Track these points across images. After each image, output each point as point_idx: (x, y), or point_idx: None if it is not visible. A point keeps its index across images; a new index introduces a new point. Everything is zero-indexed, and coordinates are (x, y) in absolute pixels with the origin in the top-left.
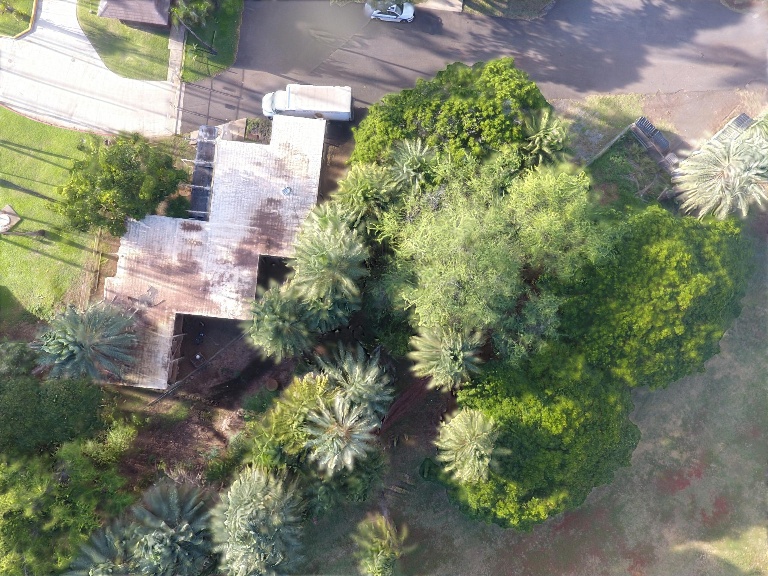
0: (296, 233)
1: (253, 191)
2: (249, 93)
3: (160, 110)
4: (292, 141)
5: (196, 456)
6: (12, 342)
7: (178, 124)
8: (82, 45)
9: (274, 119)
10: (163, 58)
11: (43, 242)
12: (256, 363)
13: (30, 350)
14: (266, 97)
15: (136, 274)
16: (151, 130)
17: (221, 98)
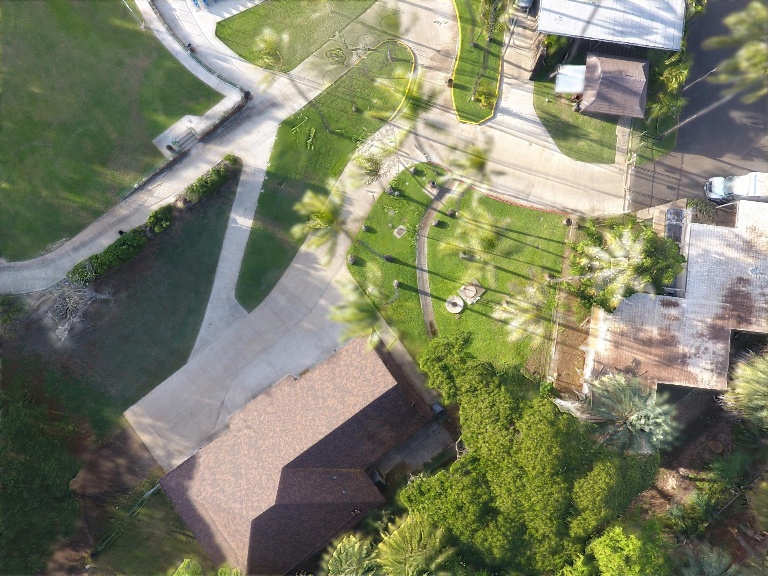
0: (763, 309)
1: (724, 270)
2: (688, 175)
3: (609, 191)
4: (758, 224)
5: (642, 513)
6: None
7: (626, 204)
8: (538, 131)
9: (741, 204)
10: (611, 143)
11: (505, 312)
12: (691, 425)
13: (591, 424)
14: (717, 181)
15: (621, 346)
16: (601, 209)
17: (663, 180)
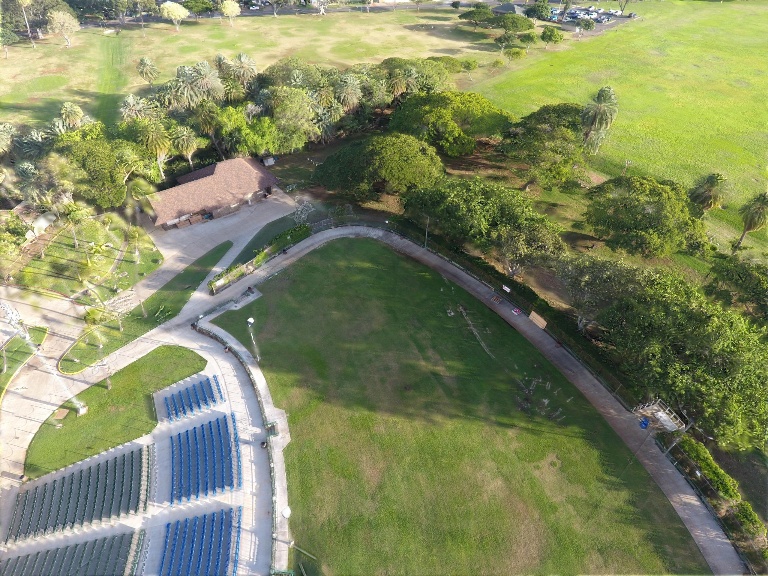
0: None
1: None
2: None
3: None
4: None
5: None
6: (118, 215)
7: None
8: None
9: None
10: None
11: None
12: None
13: (56, 177)
14: None
15: None
16: None
17: None
